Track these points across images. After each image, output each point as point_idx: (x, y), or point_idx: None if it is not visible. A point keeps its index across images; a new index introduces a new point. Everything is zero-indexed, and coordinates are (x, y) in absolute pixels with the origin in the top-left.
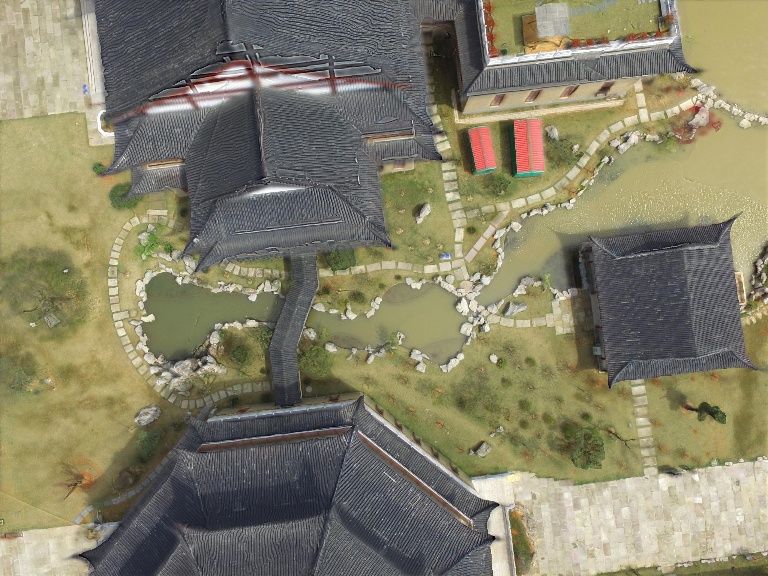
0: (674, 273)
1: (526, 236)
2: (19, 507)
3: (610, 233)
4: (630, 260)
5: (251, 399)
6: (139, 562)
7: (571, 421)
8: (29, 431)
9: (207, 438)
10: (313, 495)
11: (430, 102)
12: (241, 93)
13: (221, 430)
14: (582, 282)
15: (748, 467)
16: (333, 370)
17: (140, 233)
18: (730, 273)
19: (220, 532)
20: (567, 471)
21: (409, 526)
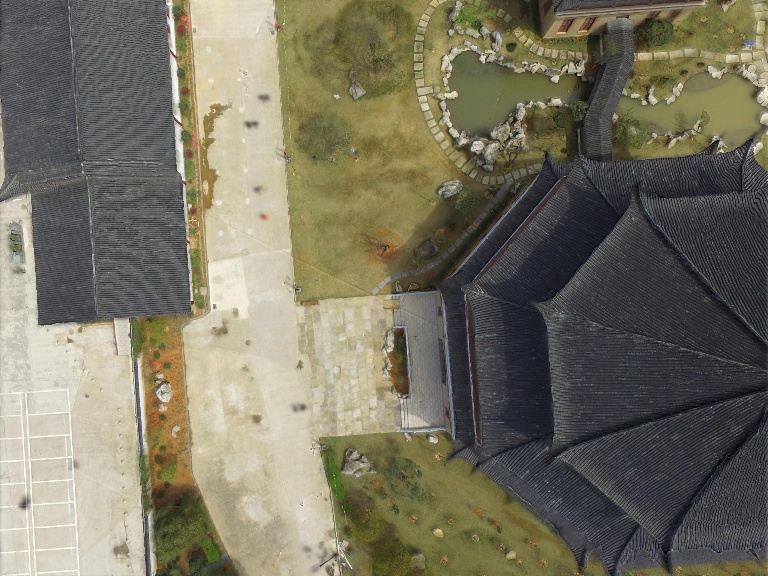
0: None
1: None
2: (316, 276)
3: None
4: None
5: None
6: (540, 259)
7: None
8: (329, 201)
9: (563, 174)
10: None
11: None
12: None
13: None
14: None
15: None
16: (633, 154)
17: (447, 10)
18: None
19: None
20: None
21: None
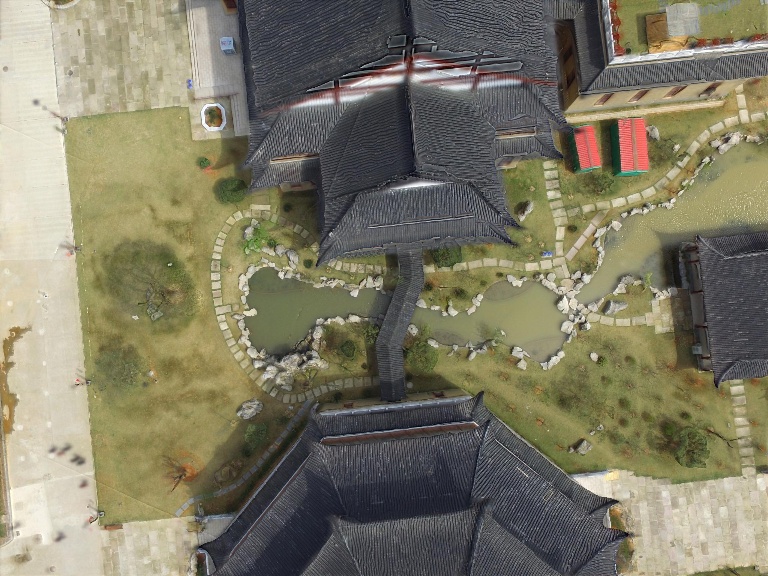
0: None
1: (626, 235)
2: (120, 499)
3: (709, 233)
4: (739, 260)
5: (352, 394)
6: (275, 554)
7: (670, 420)
8: (130, 423)
9: (327, 432)
10: (453, 489)
11: None
12: (388, 88)
13: (340, 424)
14: (682, 282)
15: None
16: None
17: (243, 227)
18: None
19: (373, 524)
20: (666, 470)
21: (544, 521)
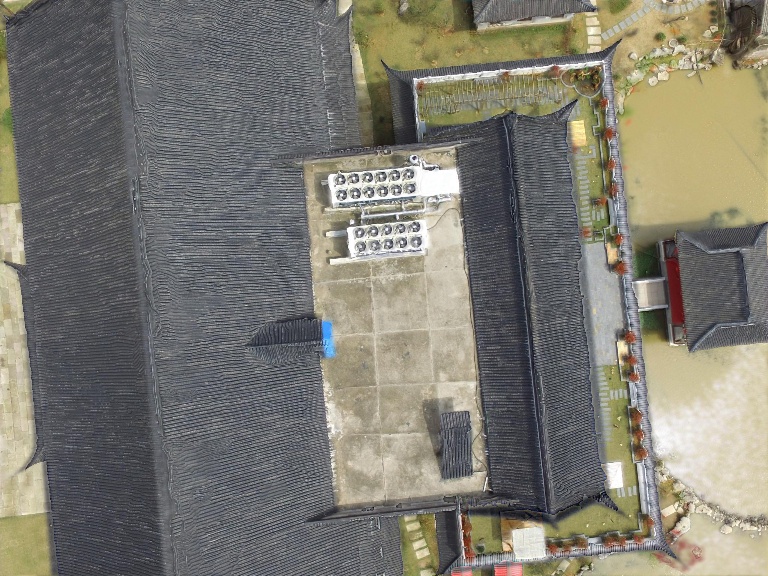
0: None
1: None
2: None
3: None
4: None
5: None
6: None
7: None
8: None
9: None
10: None
11: None
12: None
13: None
14: None
15: None
16: None
17: None
18: None
19: None
20: None
21: None
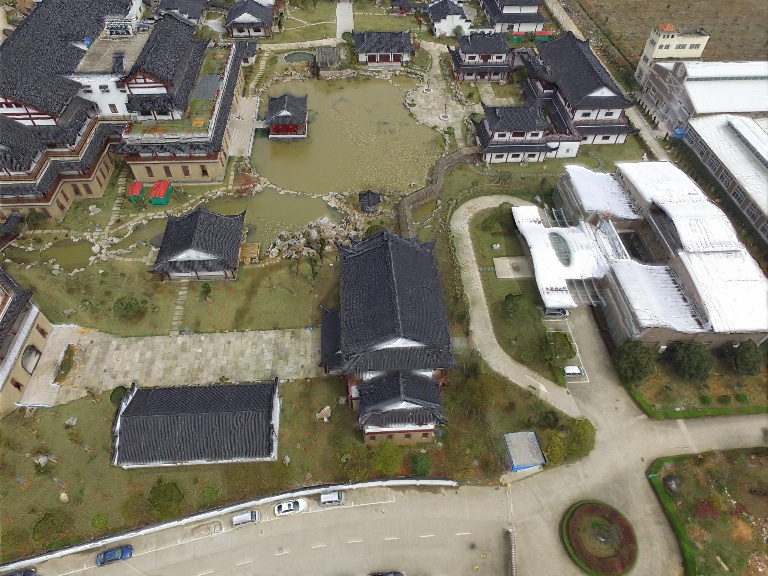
0: None
1: (149, 226)
2: None
3: None
4: None
5: None
6: None
7: None
8: None
9: None
10: None
11: (124, 177)
12: None
13: None
14: None
15: (238, 334)
16: None
17: None
18: (238, 232)
19: None
20: (119, 329)
21: None
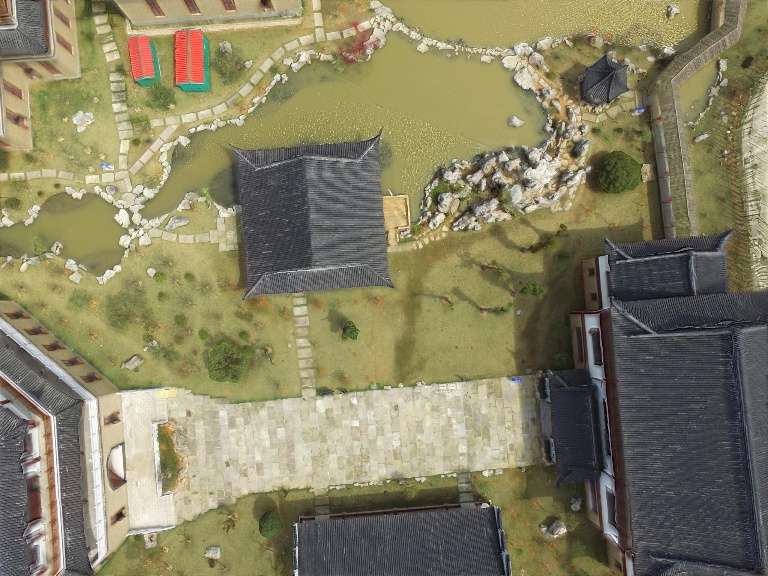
0: (298, 182)
1: (196, 151)
2: None
3: None
4: (267, 171)
5: None
6: None
7: (229, 339)
8: None
9: None
10: None
11: (101, 11)
12: None
13: None
14: None
15: (407, 392)
16: None
17: None
18: (375, 190)
19: None
20: (223, 389)
21: None
